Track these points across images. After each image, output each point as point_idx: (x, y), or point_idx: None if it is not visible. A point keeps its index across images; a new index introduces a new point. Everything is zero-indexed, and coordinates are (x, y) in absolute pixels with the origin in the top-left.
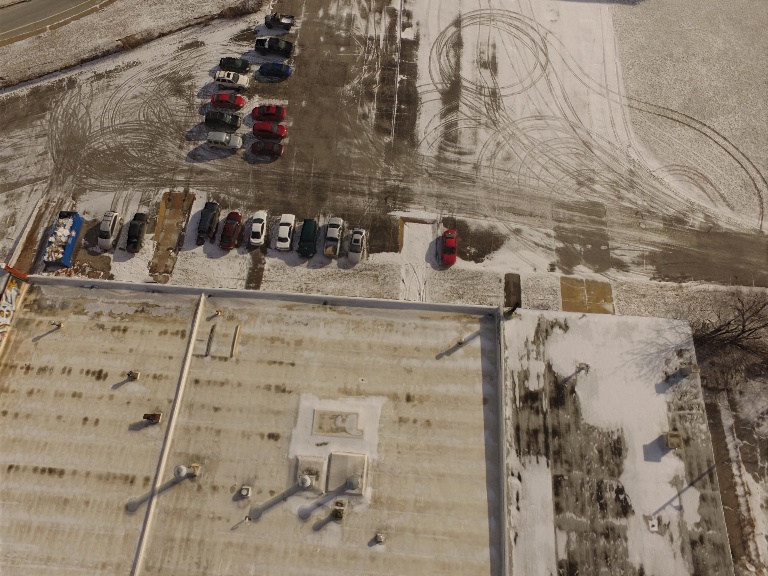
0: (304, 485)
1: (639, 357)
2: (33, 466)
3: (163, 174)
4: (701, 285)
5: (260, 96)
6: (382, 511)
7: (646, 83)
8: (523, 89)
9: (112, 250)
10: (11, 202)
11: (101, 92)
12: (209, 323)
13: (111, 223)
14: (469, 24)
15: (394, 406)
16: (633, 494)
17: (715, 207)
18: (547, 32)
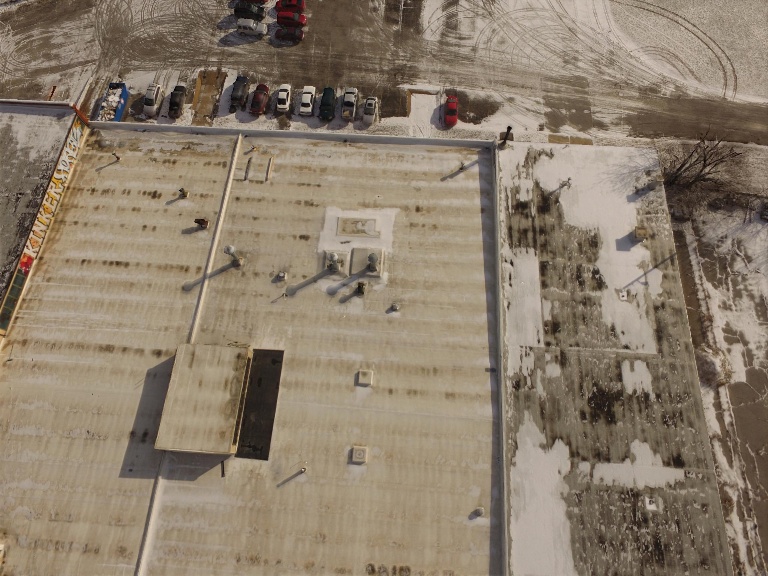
0: (333, 259)
1: (613, 176)
2: (102, 260)
3: (198, 56)
4: (671, 140)
5: None
6: (397, 289)
7: None
8: None
9: (155, 117)
10: (65, 80)
11: None
12: (246, 156)
13: (155, 92)
14: None
15: (406, 215)
16: (607, 274)
17: (684, 80)
18: None
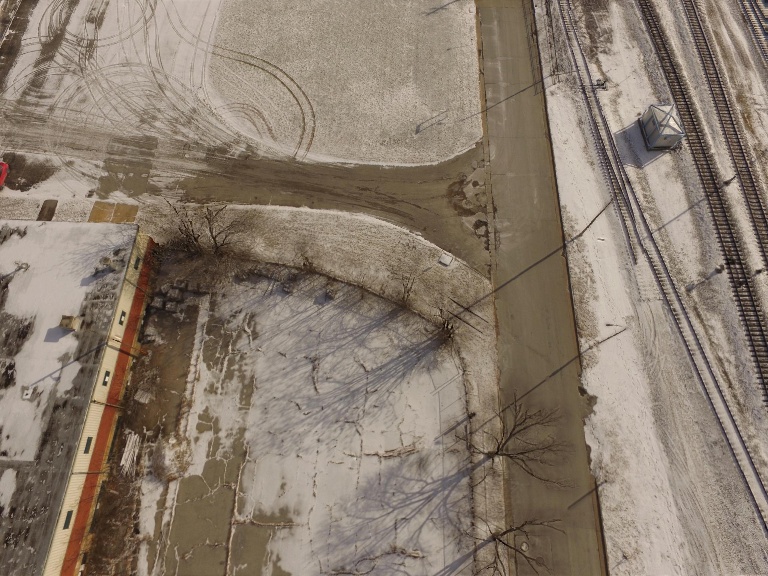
0: None
1: (78, 256)
2: None
3: None
4: (221, 205)
5: None
6: None
7: (237, 33)
8: (120, 40)
9: None
10: None
11: None
12: None
13: None
14: None
15: None
16: (20, 369)
17: (260, 138)
18: None
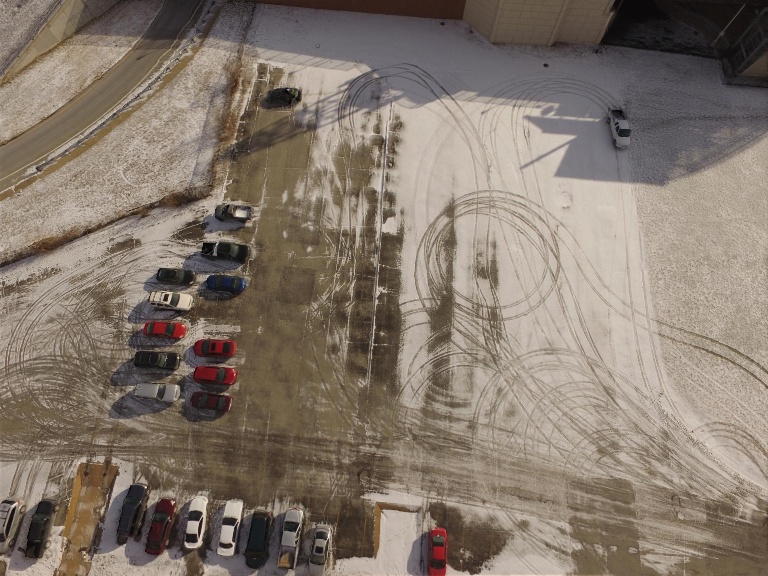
0: None
1: None
2: None
3: (80, 436)
4: None
5: (206, 320)
6: None
7: (679, 299)
8: (530, 309)
9: (9, 552)
10: None
11: (9, 313)
12: None
13: (6, 521)
14: (464, 212)
15: None
16: None
17: None
18: (558, 224)
